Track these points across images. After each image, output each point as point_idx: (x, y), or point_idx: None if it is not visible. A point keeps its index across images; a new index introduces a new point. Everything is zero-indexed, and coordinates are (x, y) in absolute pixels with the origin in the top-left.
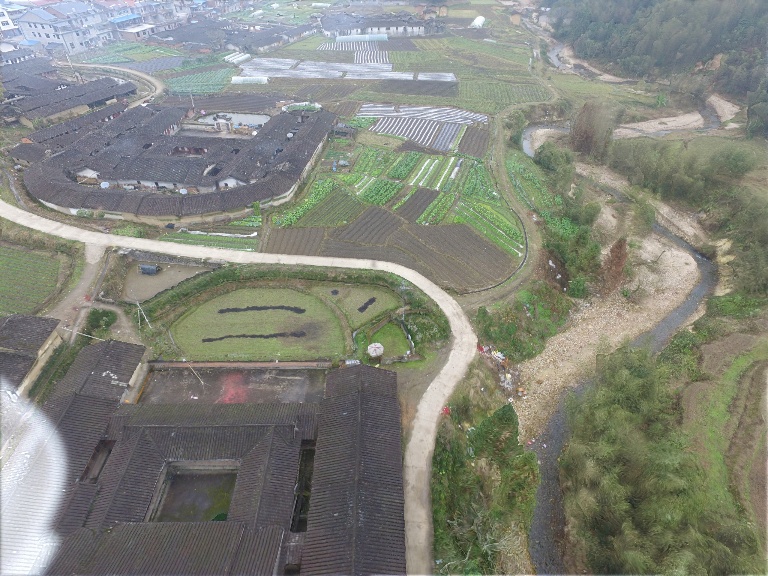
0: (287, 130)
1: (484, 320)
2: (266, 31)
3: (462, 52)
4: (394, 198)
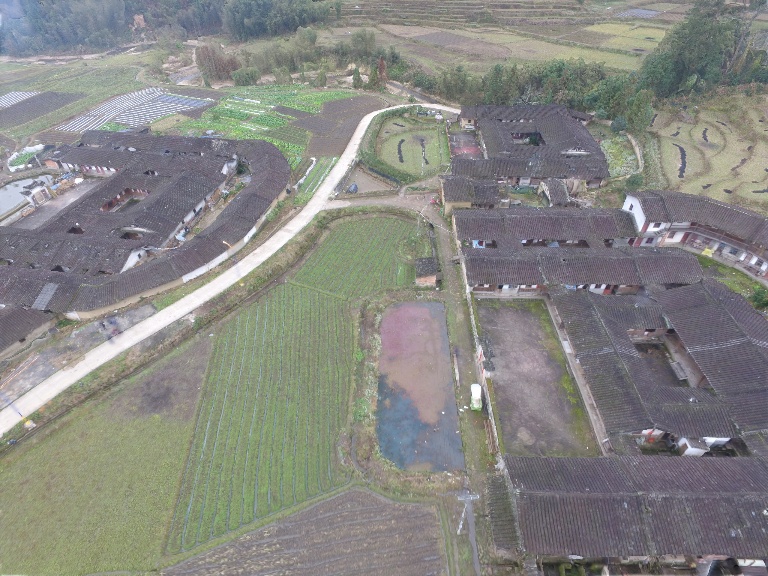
0: None
1: None
2: None
3: None
4: None
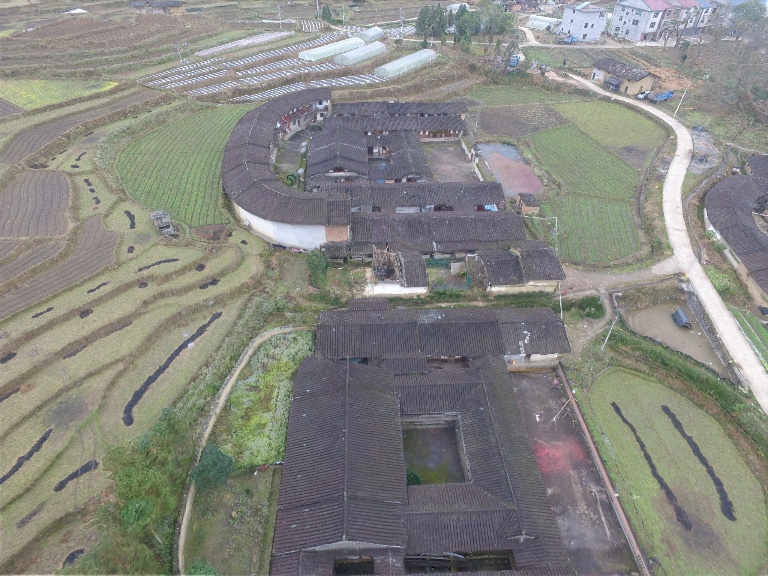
0: None
1: None
2: None
3: None
4: None
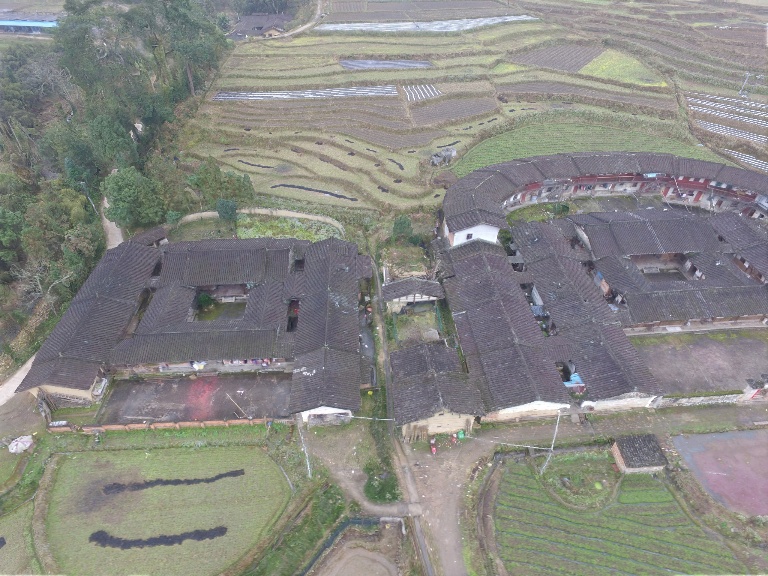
0: None
1: None
2: None
3: None
4: None
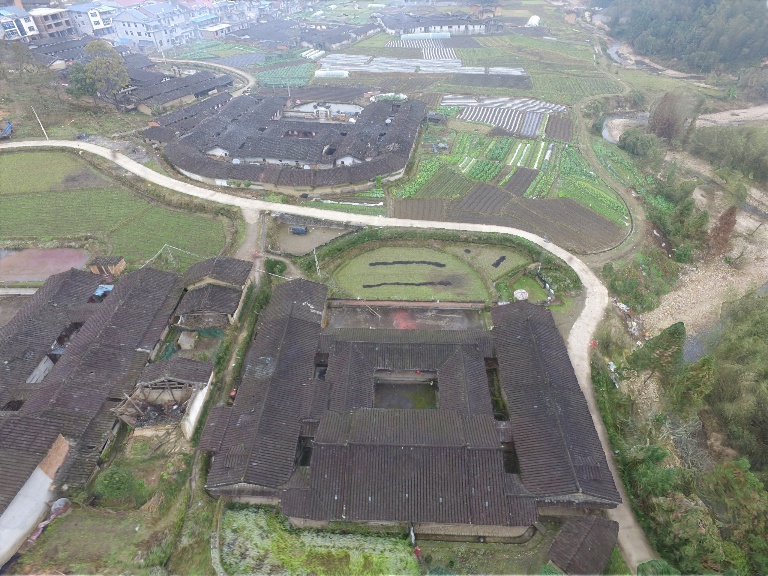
0: (384, 117)
1: (610, 275)
2: (335, 30)
3: (526, 49)
4: (498, 176)
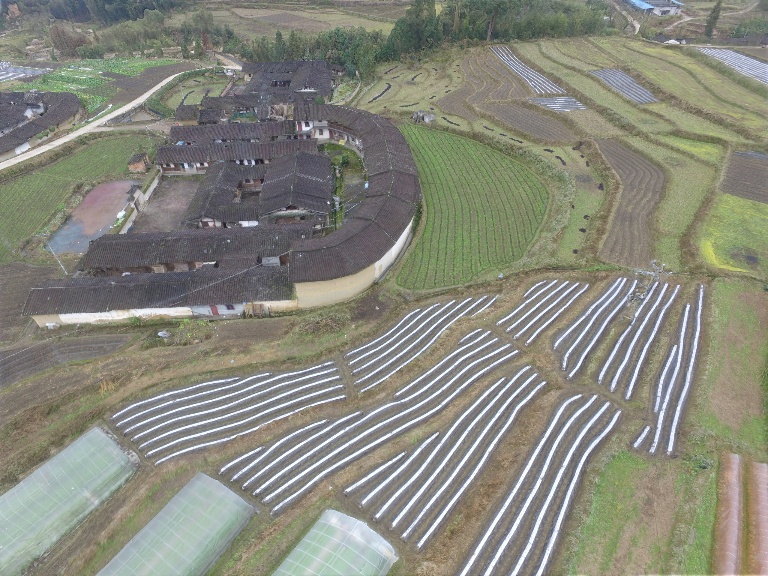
0: None
1: None
2: None
3: None
4: None
